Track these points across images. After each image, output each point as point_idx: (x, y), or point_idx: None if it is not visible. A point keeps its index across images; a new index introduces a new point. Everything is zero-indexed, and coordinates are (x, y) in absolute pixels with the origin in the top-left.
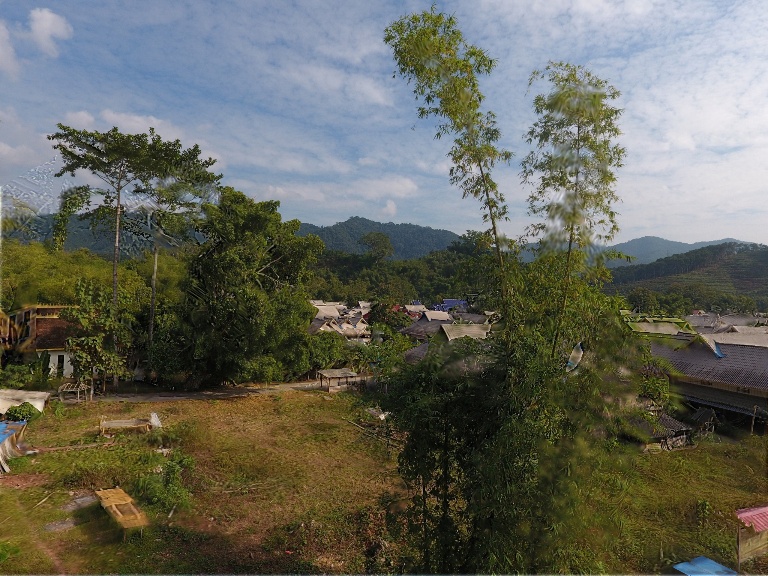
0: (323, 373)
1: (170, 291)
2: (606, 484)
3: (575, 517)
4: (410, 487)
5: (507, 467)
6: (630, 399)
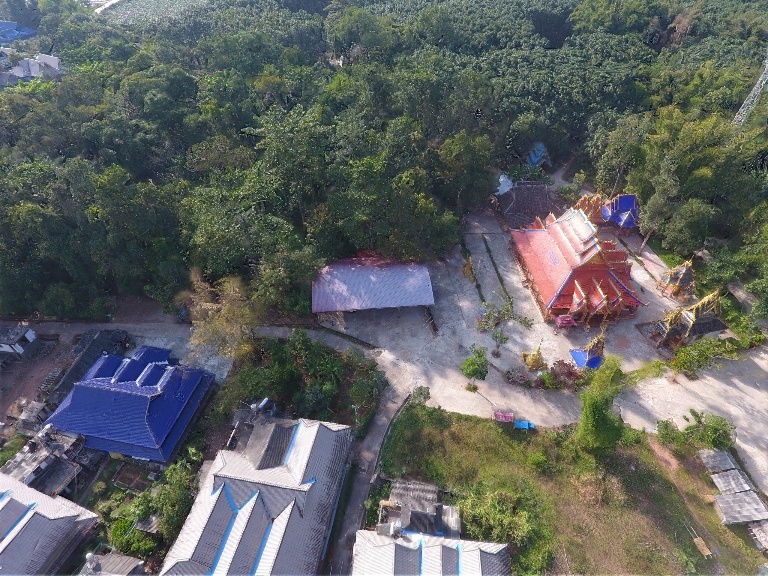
0: None
1: None
2: None
3: None
4: None
5: None
6: None
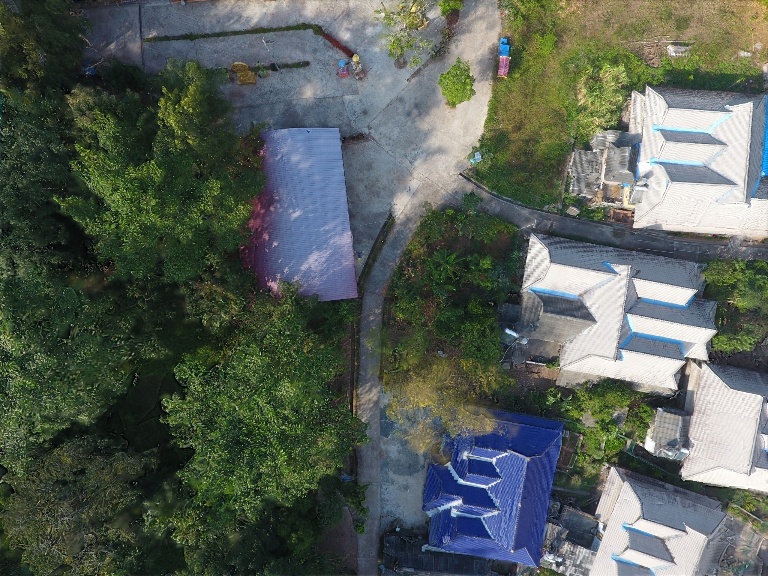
0: None
1: None
2: None
3: None
4: None
5: None
6: None
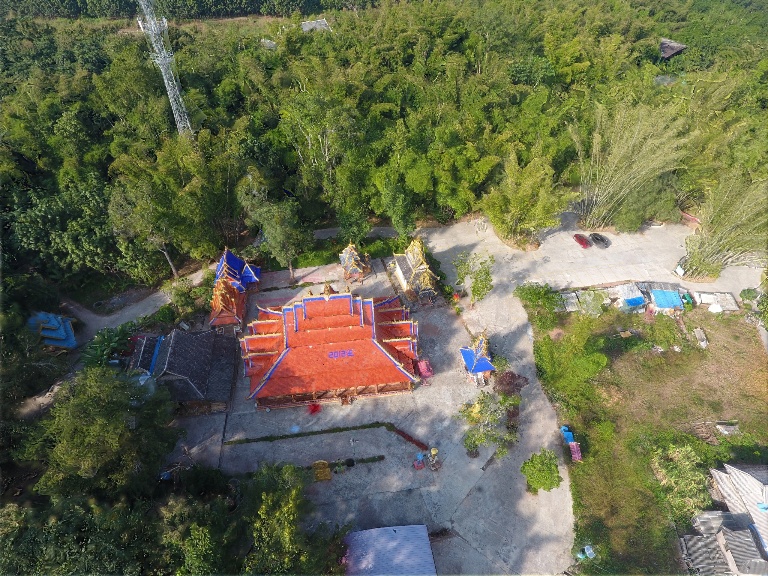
0: None
1: None
2: None
3: None
4: None
5: None
6: None
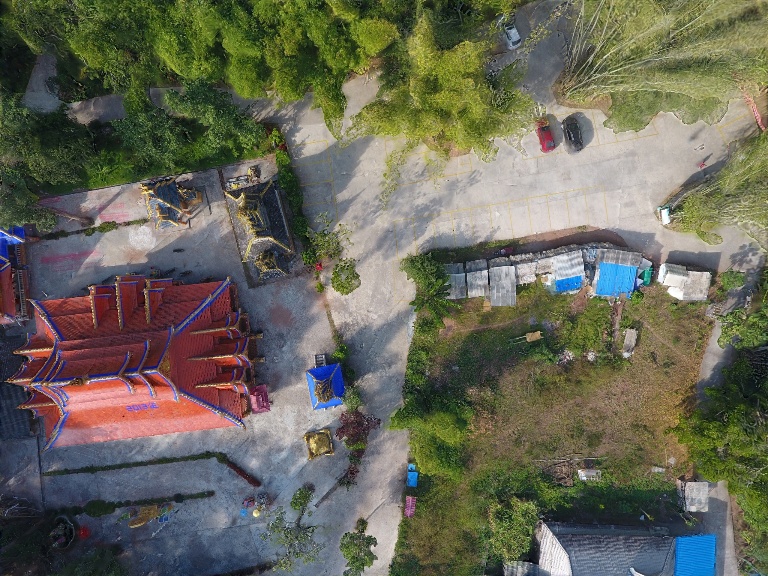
0: (697, 483)
1: None
2: None
3: None
4: None
5: None
6: None
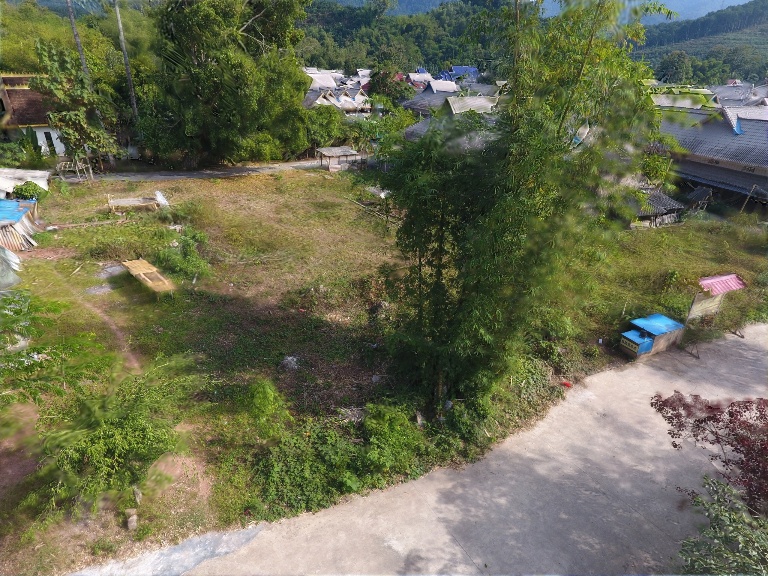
0: (322, 151)
1: (144, 56)
2: (586, 255)
3: (552, 282)
4: (407, 258)
5: (497, 241)
6: (626, 177)
